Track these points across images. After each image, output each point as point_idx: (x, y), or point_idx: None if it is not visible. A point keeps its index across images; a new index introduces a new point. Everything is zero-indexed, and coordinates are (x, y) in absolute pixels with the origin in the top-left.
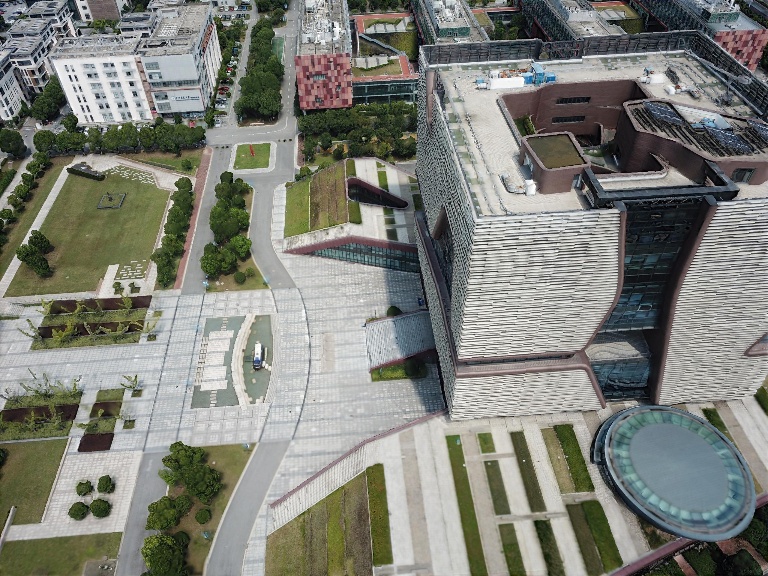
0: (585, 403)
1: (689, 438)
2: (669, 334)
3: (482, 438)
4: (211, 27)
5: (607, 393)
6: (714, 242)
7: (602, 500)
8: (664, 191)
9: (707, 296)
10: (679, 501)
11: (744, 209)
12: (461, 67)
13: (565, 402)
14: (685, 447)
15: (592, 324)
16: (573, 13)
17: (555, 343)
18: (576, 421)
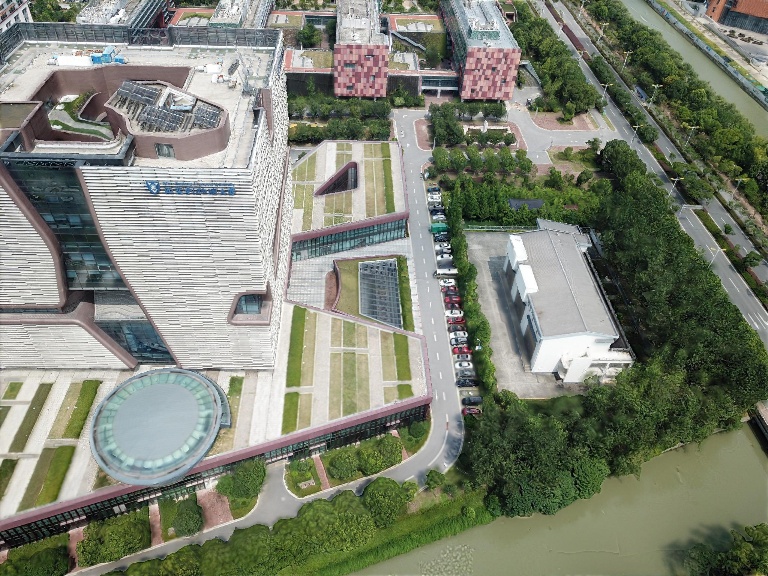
0: (107, 360)
1: (183, 398)
2: (135, 295)
3: (11, 386)
4: (18, 6)
5: (136, 354)
6: (105, 205)
7: (80, 446)
8: (56, 155)
9: (144, 259)
10: (131, 449)
11: (110, 175)
12: (60, 45)
13: (86, 358)
14: (172, 405)
15: (49, 278)
16: (346, 19)
17: (27, 295)
18: (109, 378)
